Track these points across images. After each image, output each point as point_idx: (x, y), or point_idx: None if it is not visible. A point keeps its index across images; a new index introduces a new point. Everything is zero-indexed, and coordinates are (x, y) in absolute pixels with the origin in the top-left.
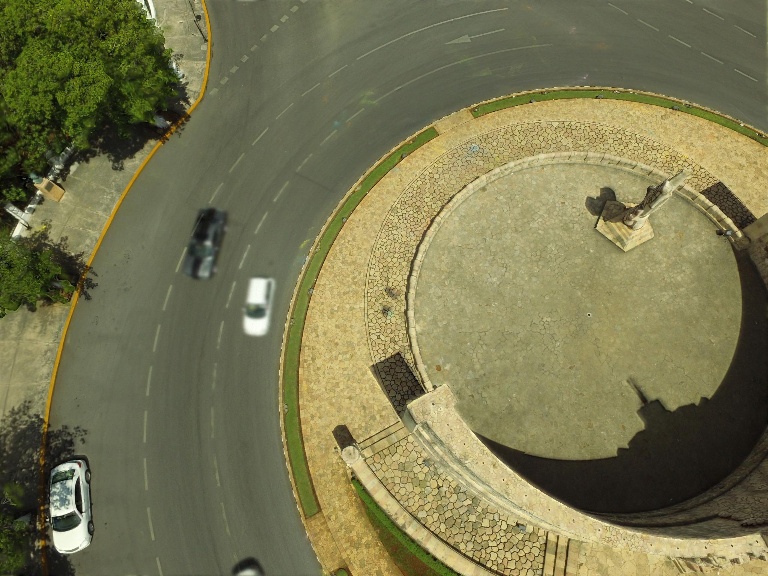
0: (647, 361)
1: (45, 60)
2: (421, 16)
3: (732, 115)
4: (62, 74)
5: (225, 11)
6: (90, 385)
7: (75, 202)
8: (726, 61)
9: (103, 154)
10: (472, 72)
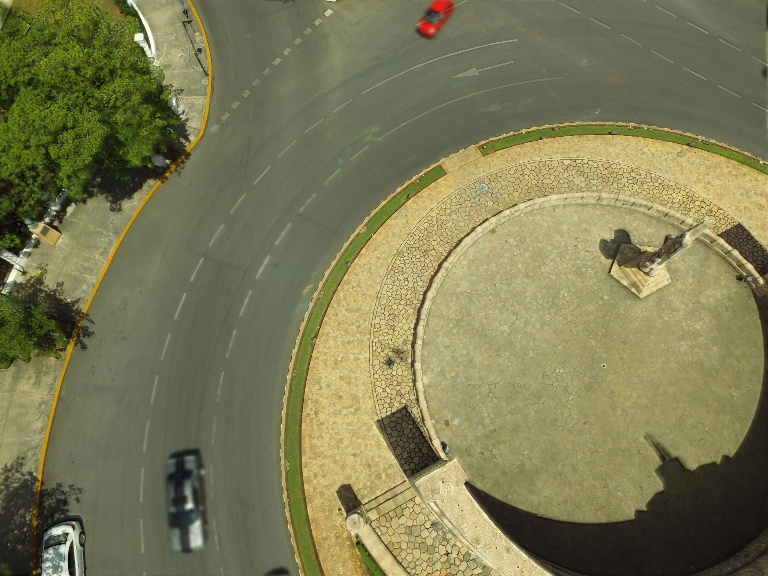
0: (665, 416)
1: (37, 113)
2: (427, 48)
3: (751, 152)
4: (55, 128)
5: (226, 44)
6: (85, 440)
7: (72, 245)
8: (744, 94)
9: (101, 194)
10: (480, 107)
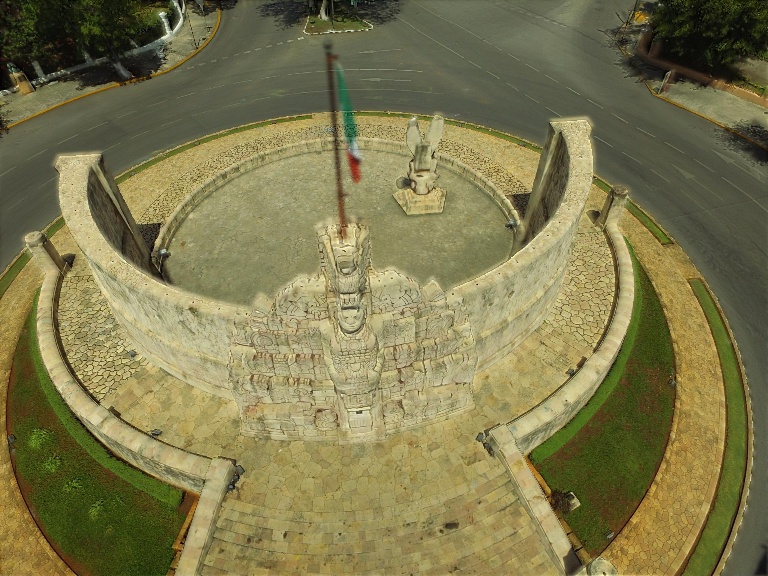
0: None
1: None
2: (354, 64)
3: None
4: None
5: (224, 40)
6: None
7: (35, 97)
8: None
9: (78, 81)
10: (367, 96)
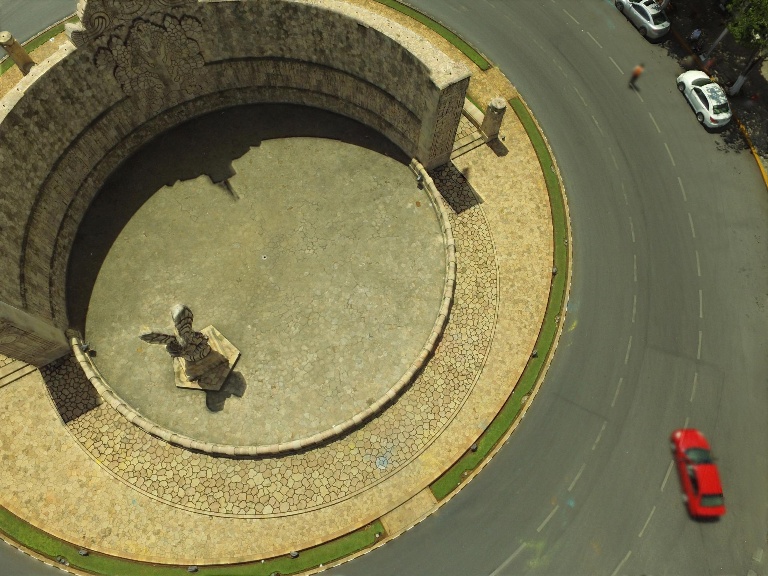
0: (215, 216)
1: None
2: None
3: (2, 546)
4: None
5: None
6: (733, 184)
7: None
8: None
9: None
10: None
